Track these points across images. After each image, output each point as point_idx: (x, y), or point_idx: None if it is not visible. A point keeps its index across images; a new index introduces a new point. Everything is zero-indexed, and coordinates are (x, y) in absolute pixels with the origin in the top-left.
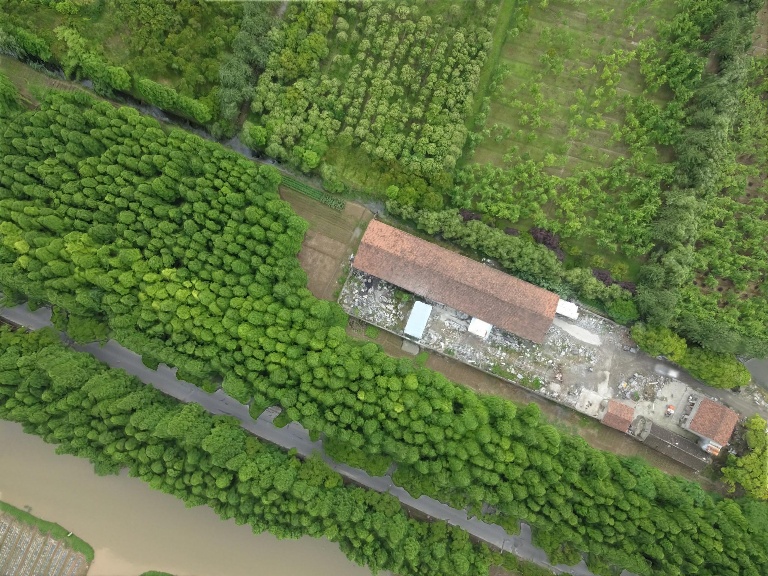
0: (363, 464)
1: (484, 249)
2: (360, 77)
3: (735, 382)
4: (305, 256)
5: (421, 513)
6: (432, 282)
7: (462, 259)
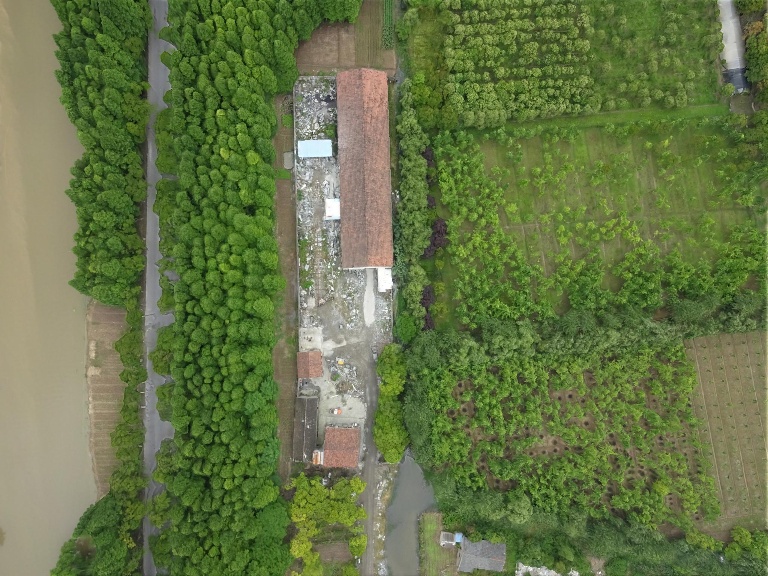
0: (162, 148)
1: (404, 180)
2: (508, 8)
3: (385, 449)
4: (329, 34)
5: (145, 231)
6: (354, 147)
7: (387, 166)
